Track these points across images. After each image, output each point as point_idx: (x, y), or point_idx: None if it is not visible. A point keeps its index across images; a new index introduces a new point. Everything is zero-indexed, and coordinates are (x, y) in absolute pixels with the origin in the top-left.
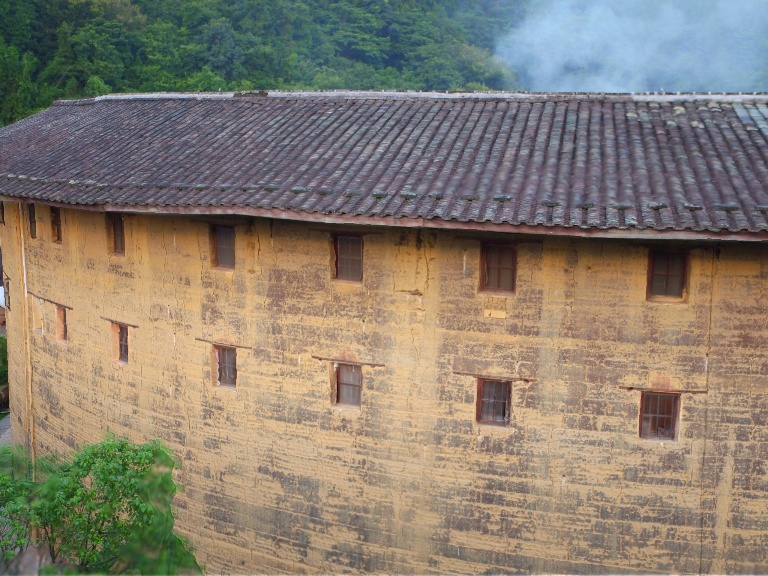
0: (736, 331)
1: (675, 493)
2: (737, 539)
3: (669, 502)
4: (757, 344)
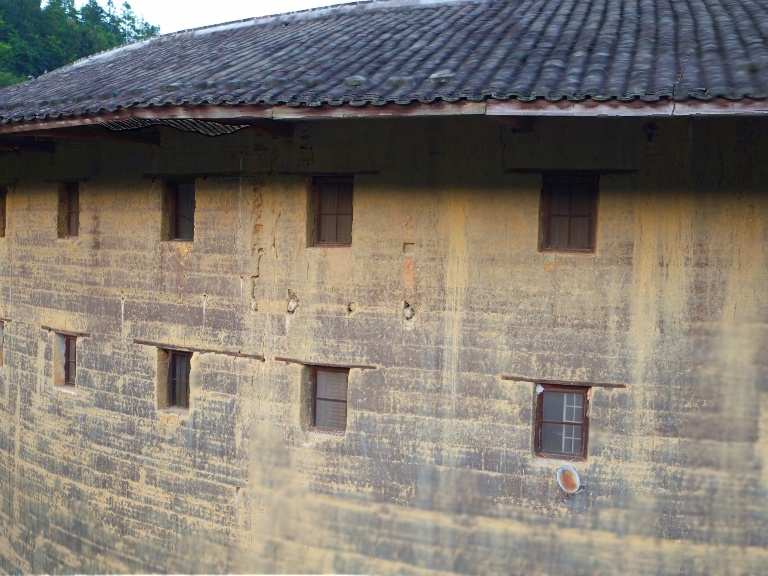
0: (20, 262)
1: (2, 417)
2: (22, 470)
3: (0, 426)
4: (28, 274)
